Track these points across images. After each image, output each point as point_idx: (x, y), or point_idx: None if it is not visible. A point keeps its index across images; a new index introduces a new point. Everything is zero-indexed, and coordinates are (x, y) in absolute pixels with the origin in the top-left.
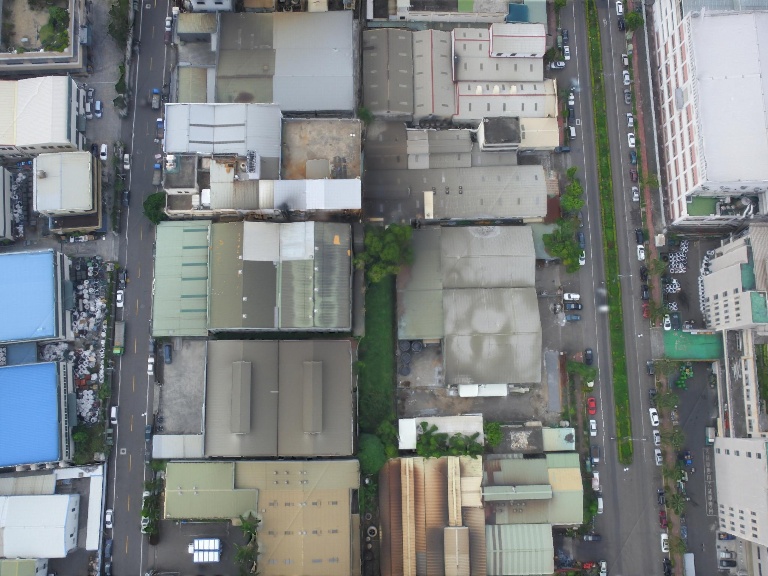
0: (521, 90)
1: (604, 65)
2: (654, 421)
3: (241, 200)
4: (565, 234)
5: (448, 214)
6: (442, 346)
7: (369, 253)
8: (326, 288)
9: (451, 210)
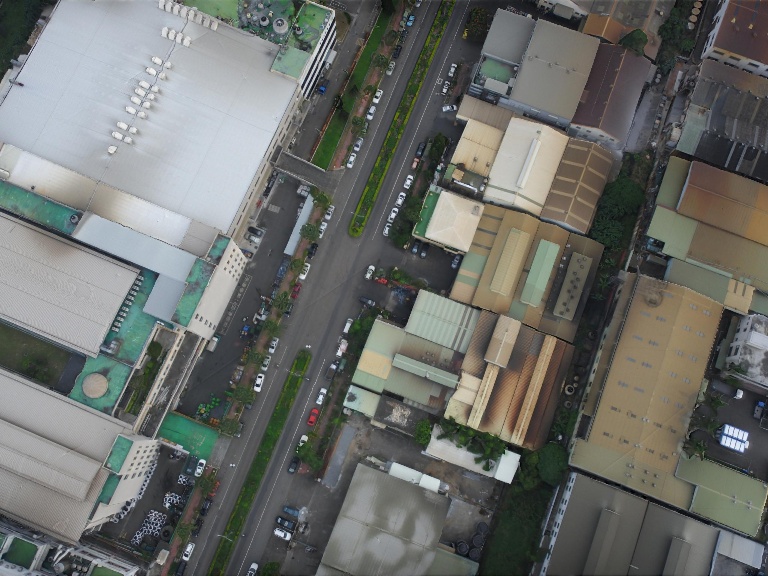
0: None
1: None
2: (262, 379)
3: None
4: None
5: None
6: None
7: None
8: None
9: None
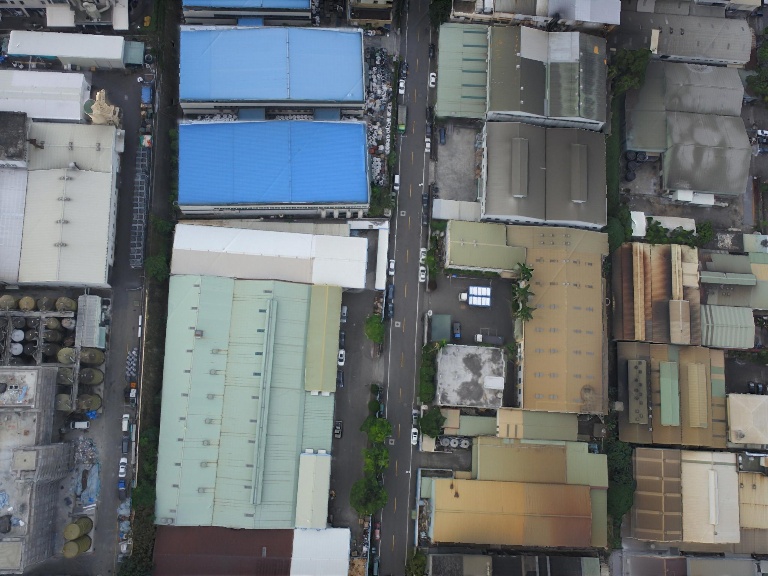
0: None
1: None
2: None
3: (521, 7)
4: None
5: (670, 51)
6: (663, 158)
7: (618, 67)
8: (588, 87)
9: (672, 48)
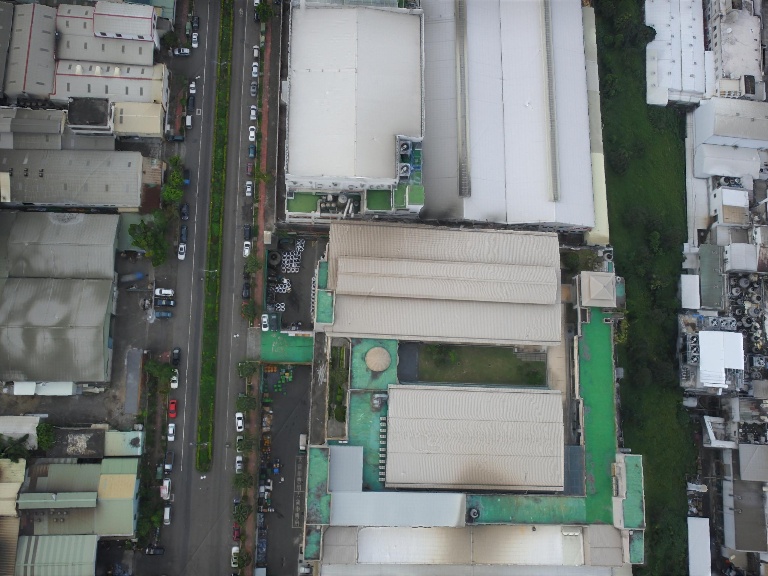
0: (126, 73)
1: (234, 55)
2: (238, 426)
3: None
4: (155, 225)
5: (27, 198)
6: None
7: None
8: None
9: (31, 194)
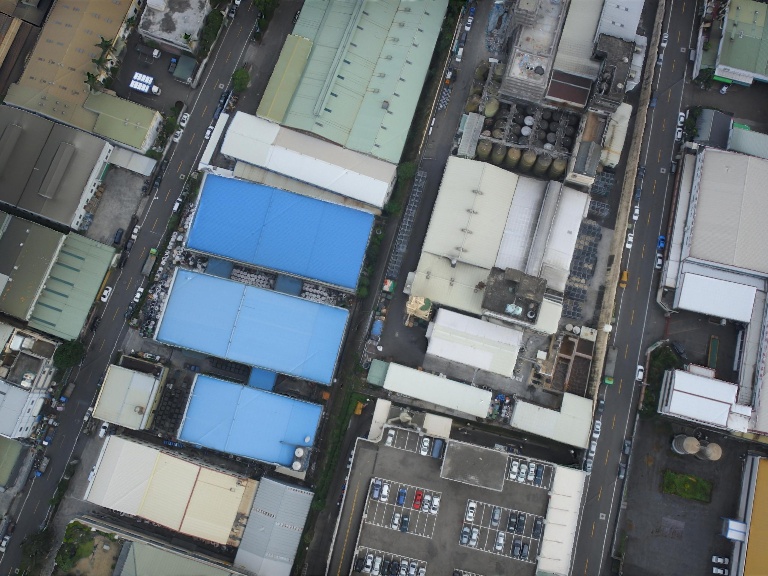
0: None
1: None
2: None
3: None
4: None
5: None
6: None
7: None
8: None
9: None
